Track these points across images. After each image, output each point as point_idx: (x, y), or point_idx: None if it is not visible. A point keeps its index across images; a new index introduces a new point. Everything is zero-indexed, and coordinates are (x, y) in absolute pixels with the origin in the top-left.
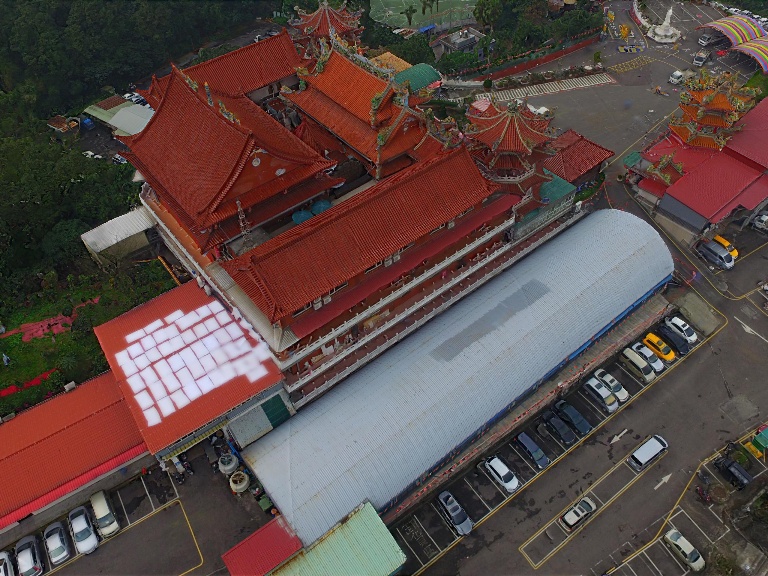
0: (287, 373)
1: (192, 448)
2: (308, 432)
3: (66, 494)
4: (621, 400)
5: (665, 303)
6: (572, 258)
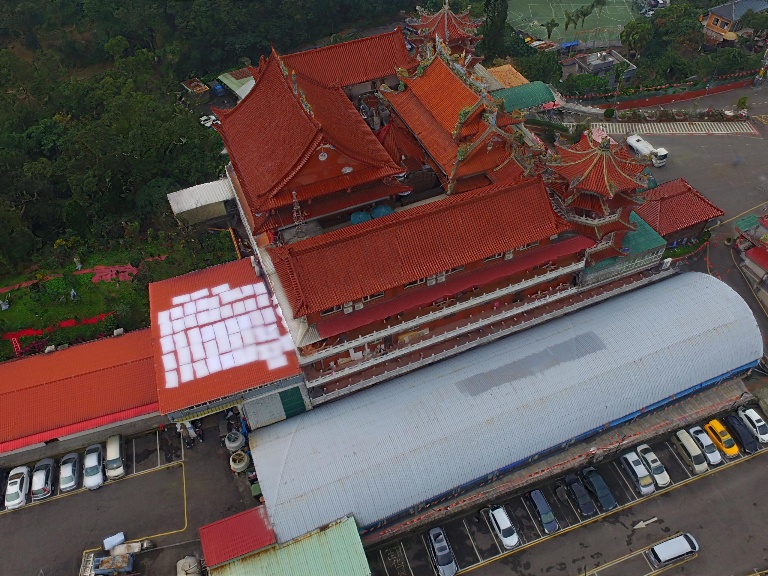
0: (311, 368)
1: (209, 417)
2: (313, 431)
3: (90, 429)
4: (659, 484)
5: (743, 390)
6: (641, 318)
